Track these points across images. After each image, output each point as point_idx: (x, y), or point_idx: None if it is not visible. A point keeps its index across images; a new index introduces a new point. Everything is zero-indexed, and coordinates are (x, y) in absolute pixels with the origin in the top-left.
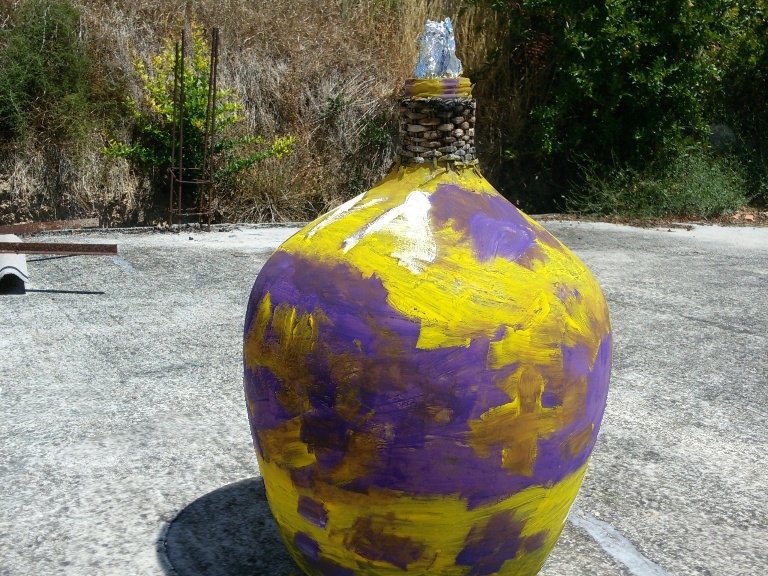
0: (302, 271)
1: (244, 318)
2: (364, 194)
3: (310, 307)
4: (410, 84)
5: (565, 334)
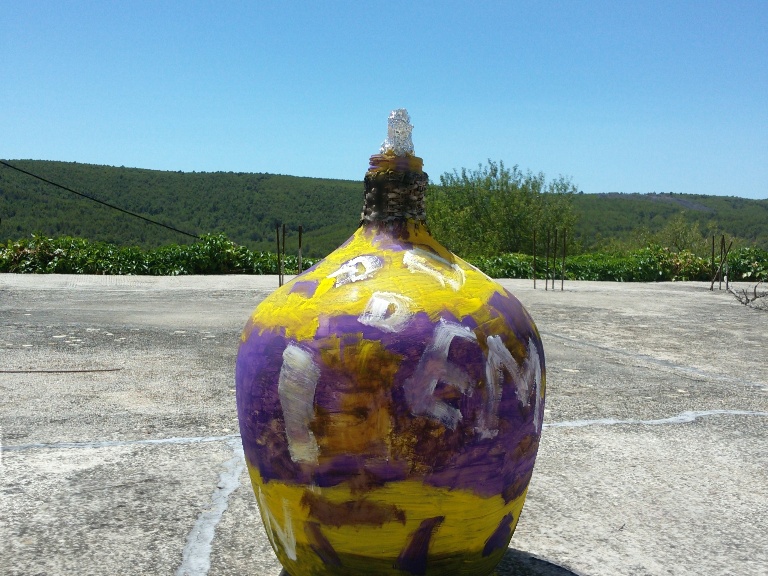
0: None
1: None
2: (450, 253)
3: None
4: None
5: None
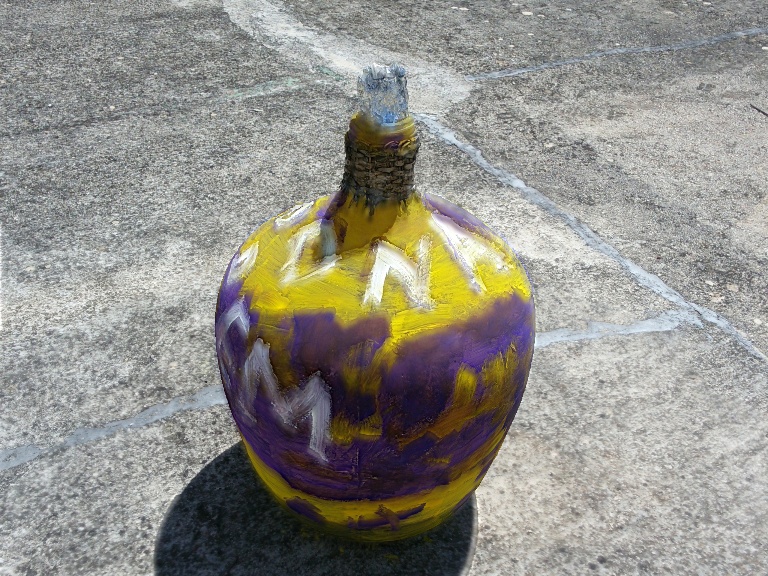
0: (482, 325)
1: (403, 413)
2: (386, 243)
3: (508, 341)
4: (403, 128)
5: None
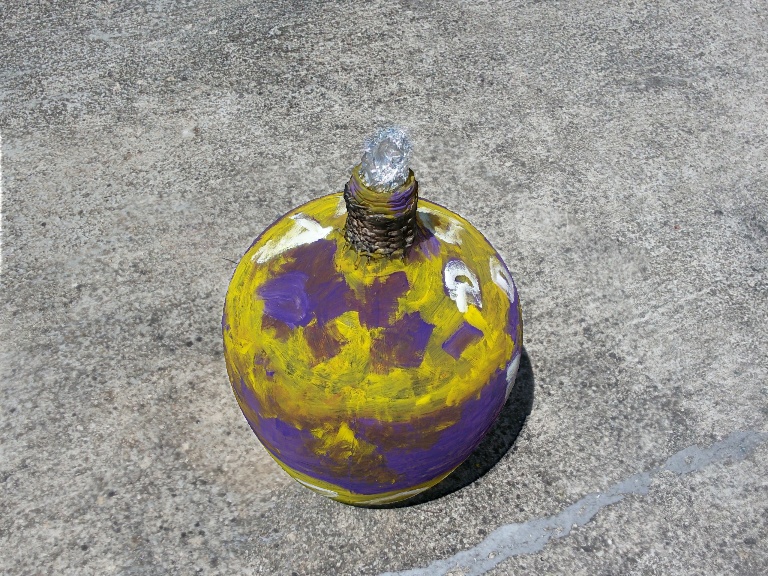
0: None
1: None
2: None
3: None
4: None
5: (246, 376)
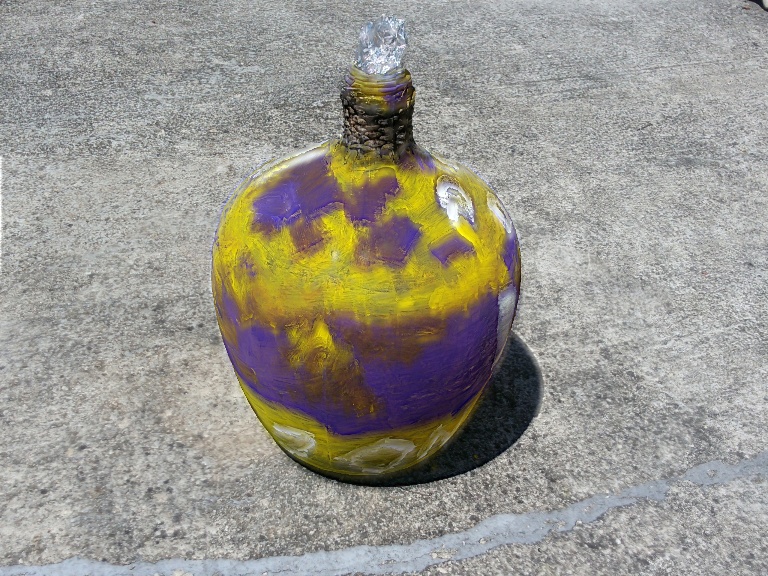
0: None
1: None
2: None
3: None
4: None
5: (227, 278)
